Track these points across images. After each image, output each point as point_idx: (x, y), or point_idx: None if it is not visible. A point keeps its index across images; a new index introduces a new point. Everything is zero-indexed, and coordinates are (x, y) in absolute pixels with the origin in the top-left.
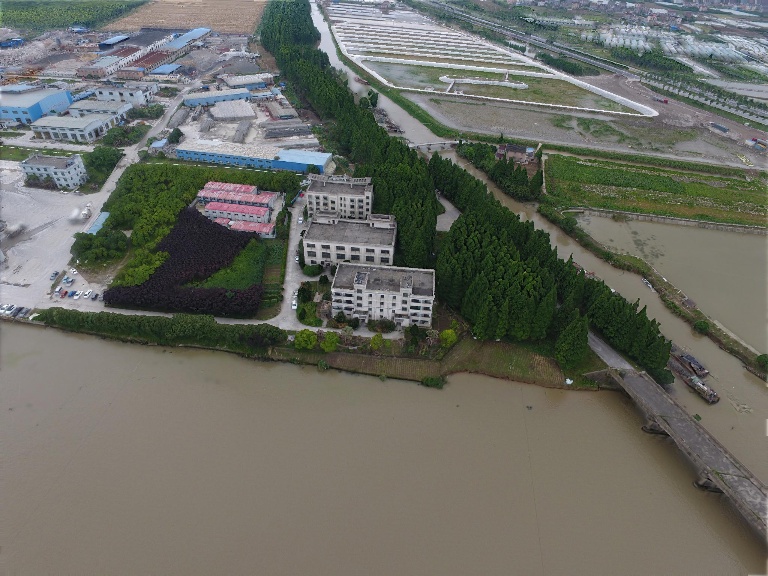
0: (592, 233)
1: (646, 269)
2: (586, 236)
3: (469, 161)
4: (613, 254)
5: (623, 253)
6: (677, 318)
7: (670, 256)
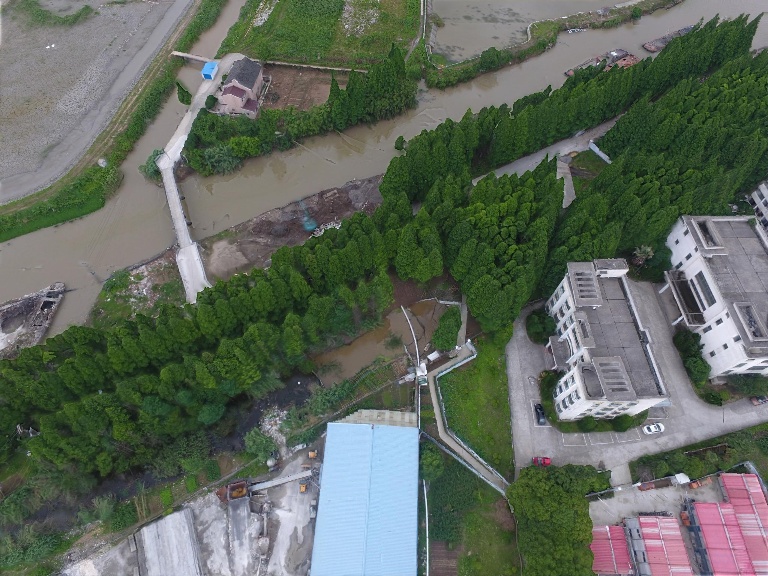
0: (485, 49)
1: (555, 24)
2: (510, 52)
3: (262, 156)
4: (539, 39)
5: (522, 35)
6: (623, 26)
7: (510, 5)
